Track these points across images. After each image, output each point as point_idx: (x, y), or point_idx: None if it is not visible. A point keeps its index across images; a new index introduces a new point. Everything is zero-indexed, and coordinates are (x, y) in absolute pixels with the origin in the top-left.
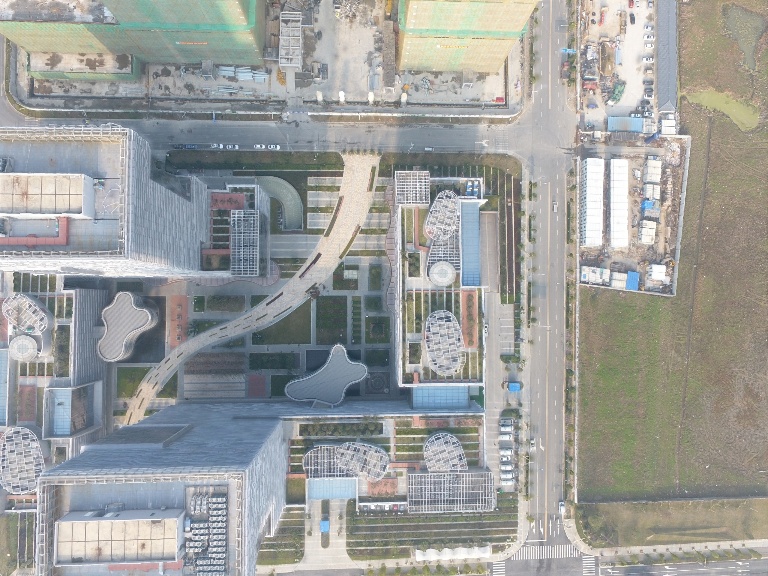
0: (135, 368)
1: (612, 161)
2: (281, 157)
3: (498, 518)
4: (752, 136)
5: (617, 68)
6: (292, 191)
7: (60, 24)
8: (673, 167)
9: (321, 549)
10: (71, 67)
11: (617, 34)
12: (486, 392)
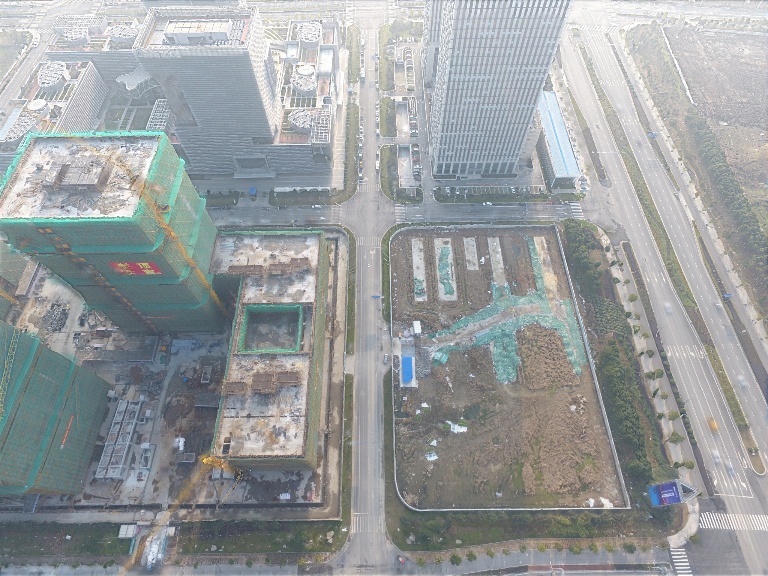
0: None
1: None
2: None
3: None
4: None
5: None
6: None
7: (267, 232)
8: None
9: None
10: None
11: None
12: None
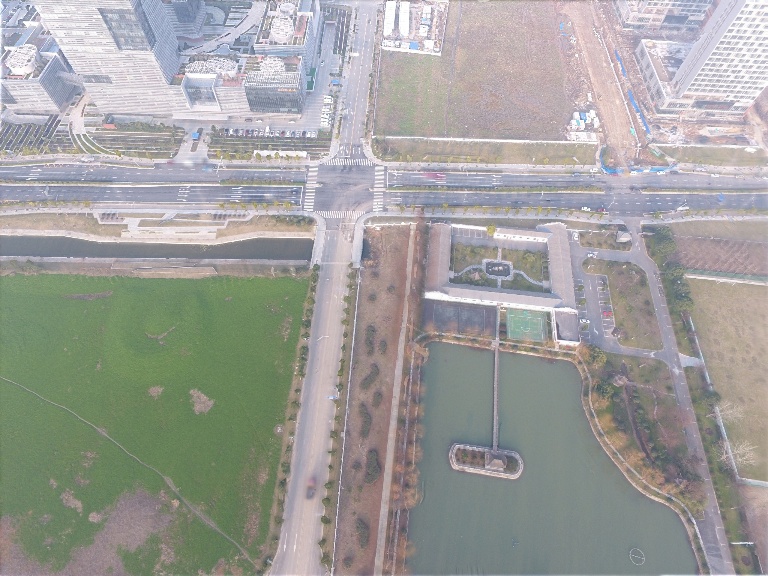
0: None
1: (401, 2)
2: (219, 2)
3: (316, 142)
4: (486, 3)
5: None
6: (221, 14)
7: None
8: (440, 11)
9: (190, 153)
10: None
11: None
12: (318, 88)
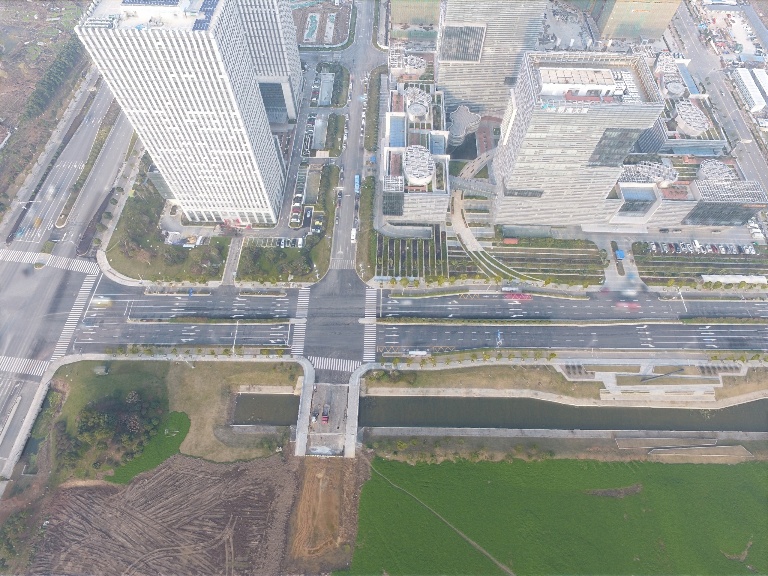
0: (457, 162)
1: (753, 69)
2: None
3: (762, 261)
4: None
5: (733, 39)
6: None
7: None
8: None
9: (619, 276)
10: (415, 29)
11: (726, 27)
12: None
